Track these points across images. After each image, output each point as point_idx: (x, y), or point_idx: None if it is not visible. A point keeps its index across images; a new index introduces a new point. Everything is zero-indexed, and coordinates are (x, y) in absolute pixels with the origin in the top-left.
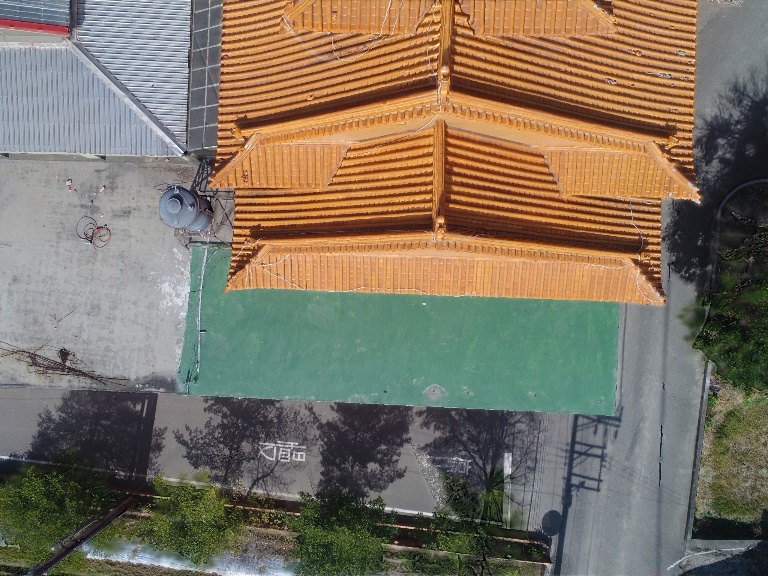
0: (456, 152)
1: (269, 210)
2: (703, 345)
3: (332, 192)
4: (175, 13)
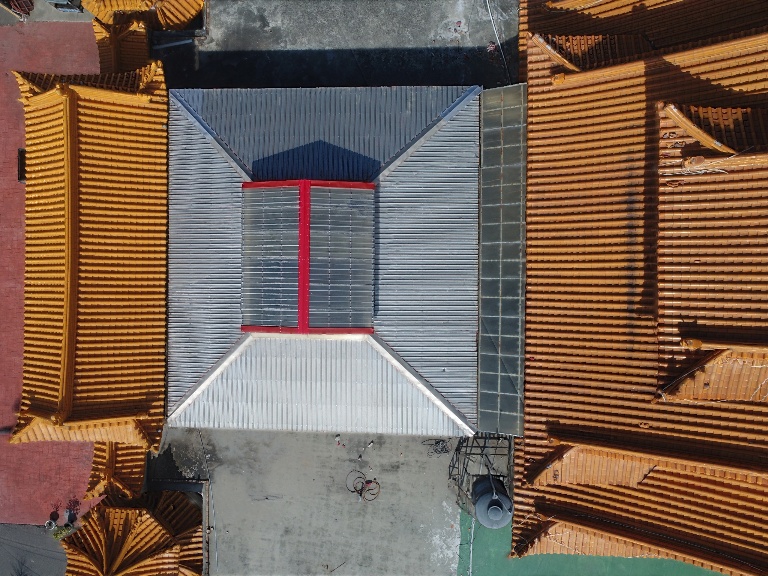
0: None
1: (556, 484)
2: None
3: (643, 491)
4: (463, 299)
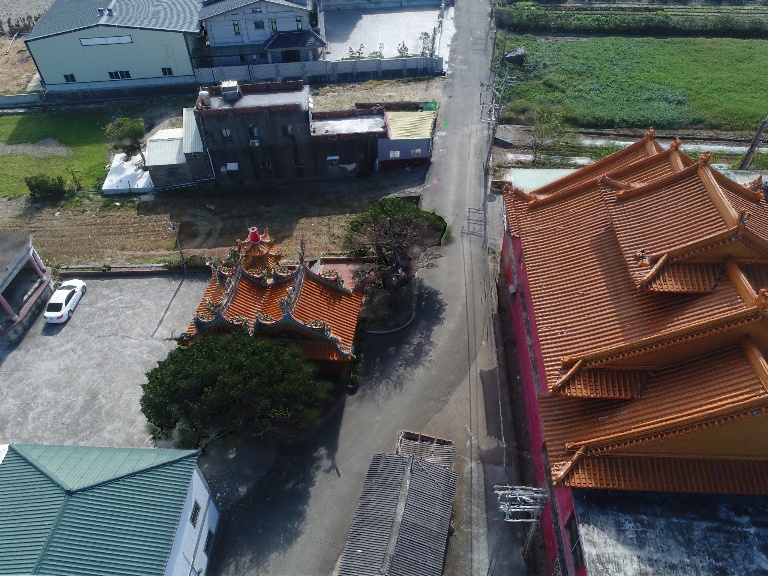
0: None
1: None
2: None
3: None
4: None
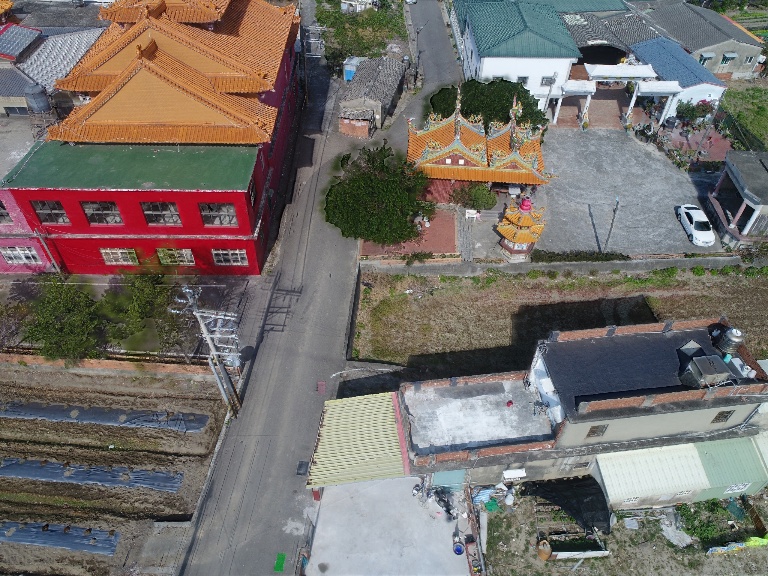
0: (161, 56)
1: None
2: (325, 209)
3: None
4: None
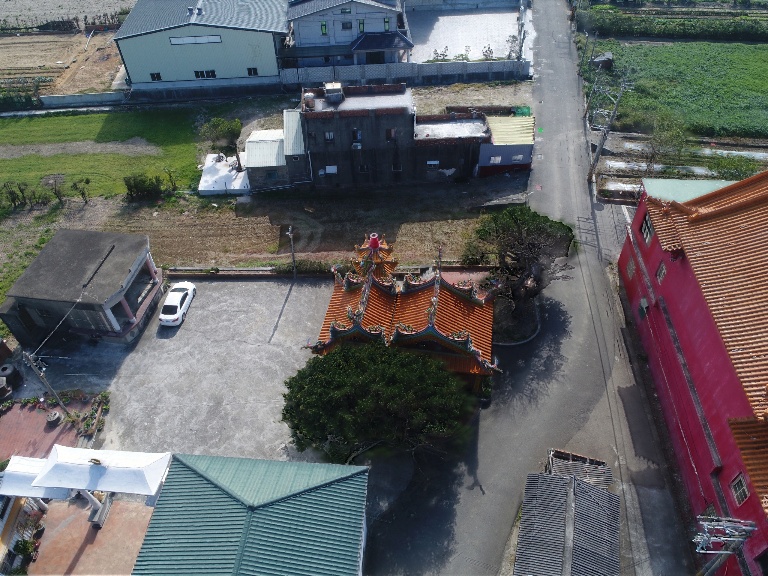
0: None
1: None
2: None
3: None
4: None
